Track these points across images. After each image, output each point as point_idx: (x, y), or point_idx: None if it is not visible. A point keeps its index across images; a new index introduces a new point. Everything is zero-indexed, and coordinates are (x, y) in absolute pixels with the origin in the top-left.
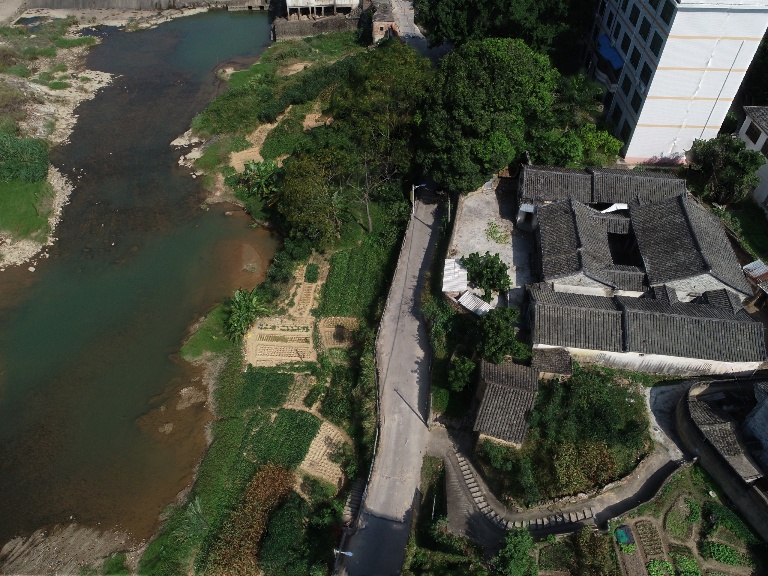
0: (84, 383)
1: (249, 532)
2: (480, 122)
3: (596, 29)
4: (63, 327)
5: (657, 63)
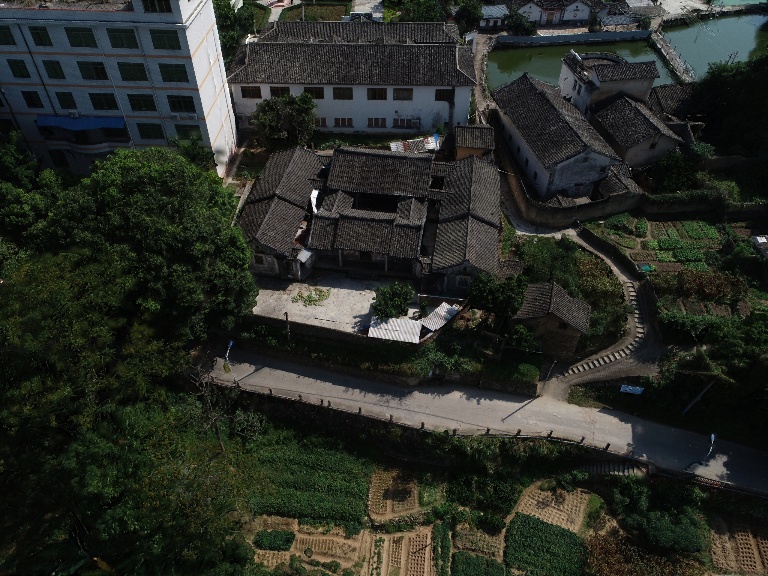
0: None
1: (668, 573)
2: (222, 235)
3: (4, 123)
4: None
5: (195, 86)
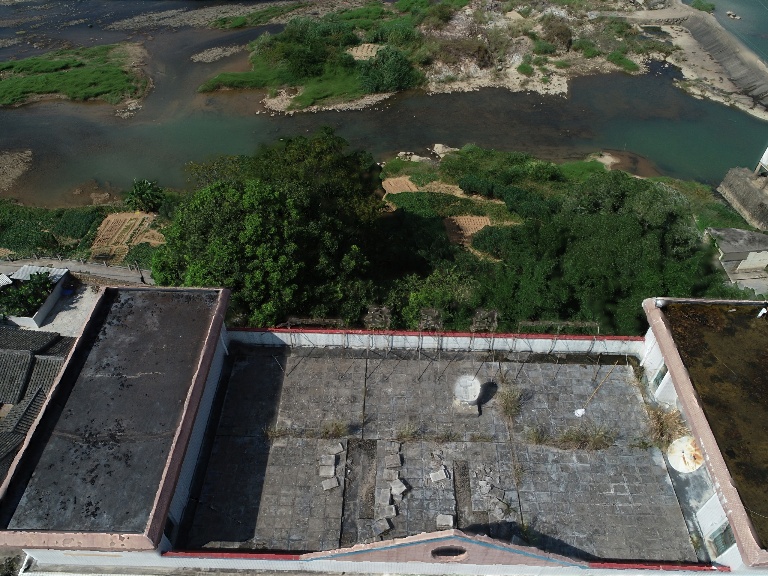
0: (137, 154)
1: None
2: None
3: None
4: (196, 137)
5: None
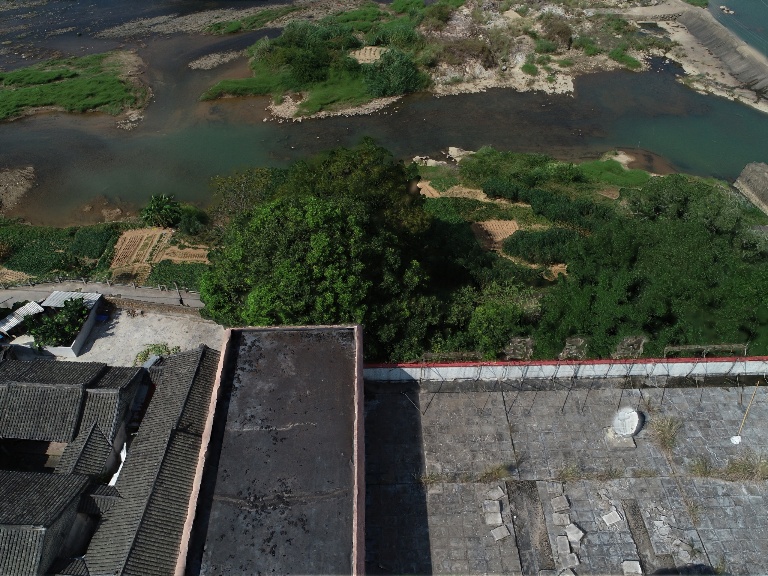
0: (144, 167)
1: None
2: None
3: None
4: (204, 147)
5: None
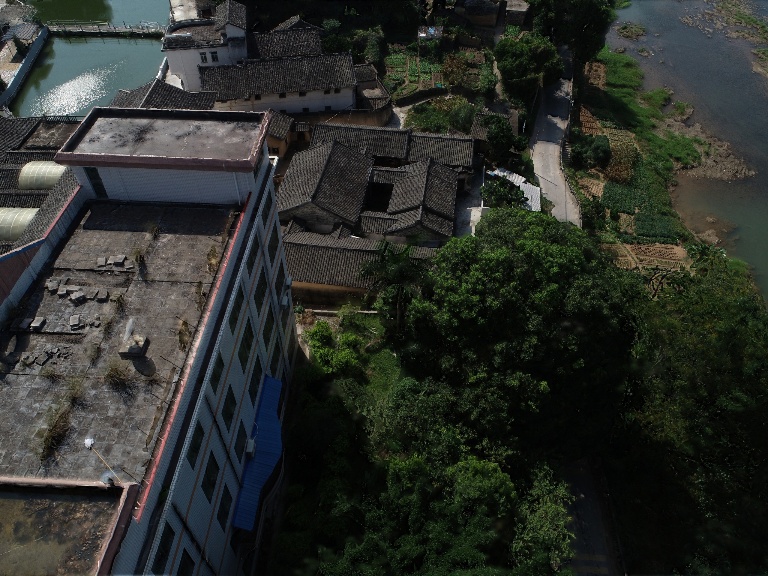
0: None
1: None
2: None
3: None
4: None
5: None
